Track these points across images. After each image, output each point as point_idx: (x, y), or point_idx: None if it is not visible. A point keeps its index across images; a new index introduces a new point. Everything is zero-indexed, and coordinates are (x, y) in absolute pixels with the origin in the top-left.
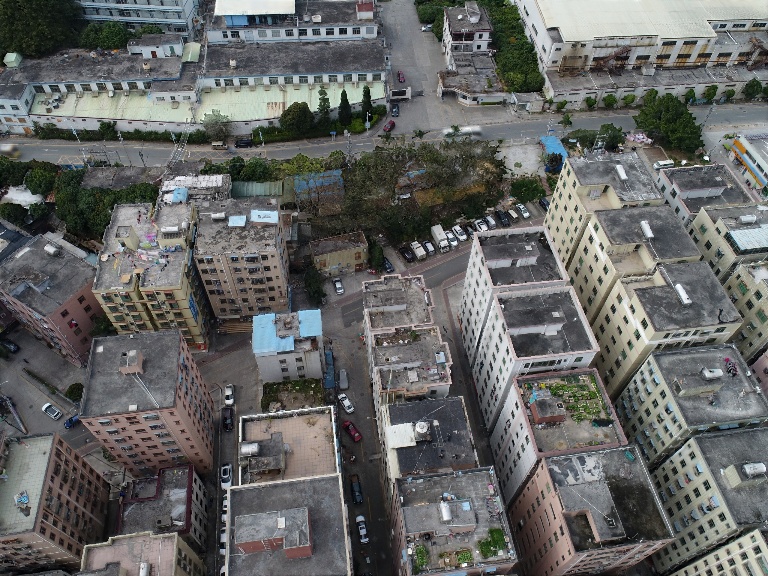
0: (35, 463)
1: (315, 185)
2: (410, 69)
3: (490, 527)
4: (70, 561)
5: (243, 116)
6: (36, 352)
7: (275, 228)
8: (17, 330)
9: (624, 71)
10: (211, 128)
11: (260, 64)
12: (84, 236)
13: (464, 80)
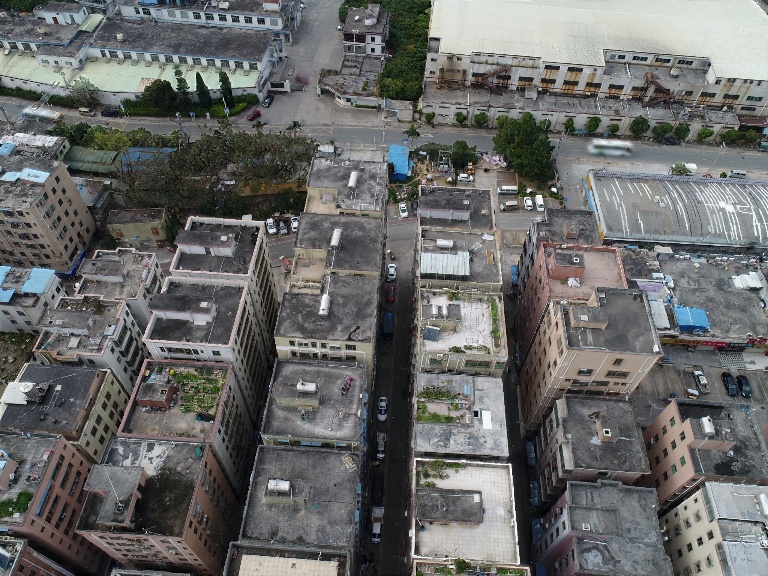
0: None
1: (141, 159)
2: (305, 64)
3: (24, 490)
4: None
5: (113, 87)
6: None
7: (41, 188)
8: None
9: (508, 91)
10: (76, 94)
11: (147, 41)
12: None
13: (342, 80)
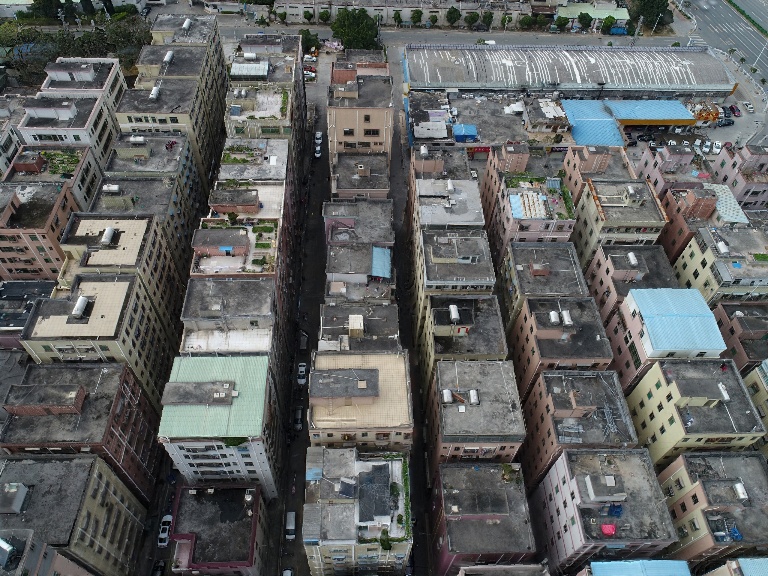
0: None
1: None
2: None
3: None
4: None
5: (7, 1)
6: None
7: None
8: None
9: None
10: None
11: None
12: None
13: None
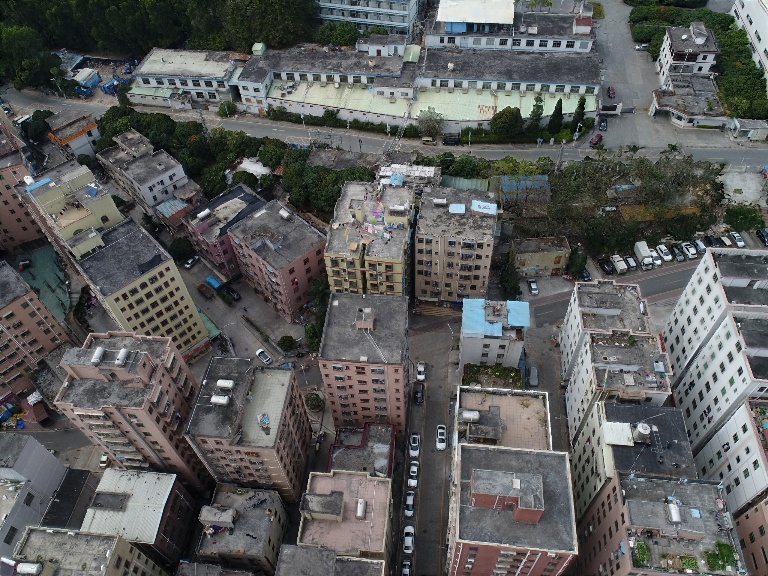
0: (275, 391)
1: (521, 187)
2: (621, 86)
3: (717, 541)
4: (282, 487)
5: (455, 116)
6: (254, 303)
7: (493, 219)
8: (239, 282)
9: None
10: (425, 124)
11: (476, 69)
12: (302, 208)
13: (681, 101)
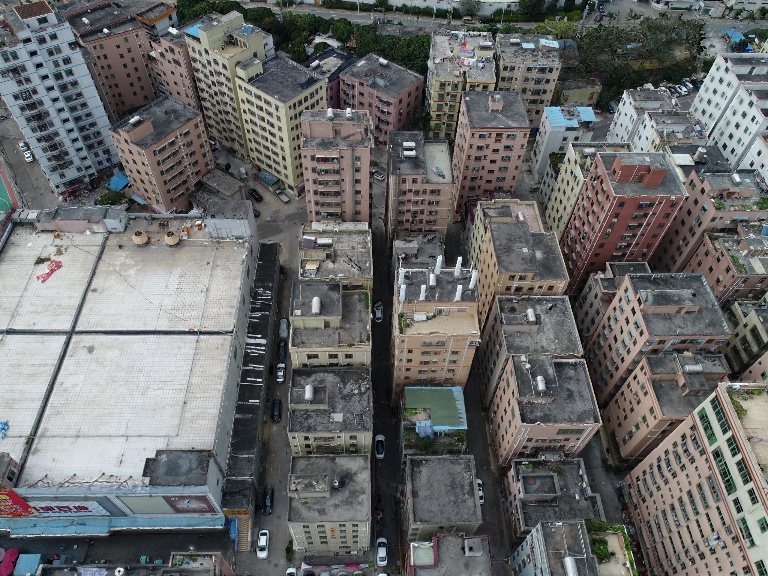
0: (438, 155)
1: None
2: None
3: (760, 197)
4: None
5: None
6: None
7: (556, 52)
8: None
9: None
10: (467, 4)
11: None
12: None
13: None
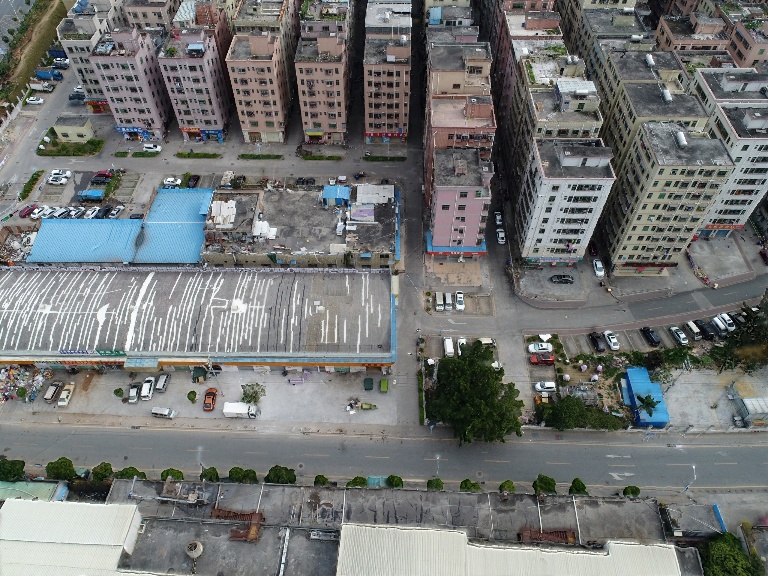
0: None
1: None
2: None
3: None
4: None
5: None
6: None
7: None
8: None
9: None
10: None
11: None
12: None
13: None
